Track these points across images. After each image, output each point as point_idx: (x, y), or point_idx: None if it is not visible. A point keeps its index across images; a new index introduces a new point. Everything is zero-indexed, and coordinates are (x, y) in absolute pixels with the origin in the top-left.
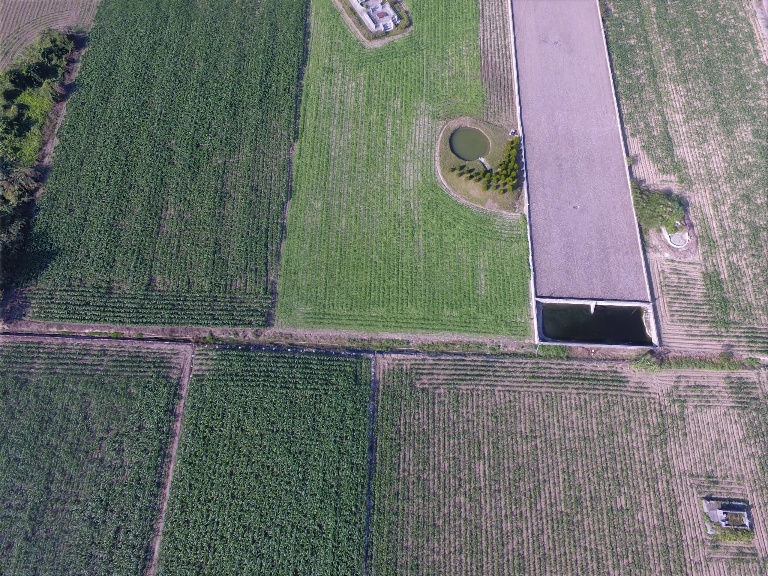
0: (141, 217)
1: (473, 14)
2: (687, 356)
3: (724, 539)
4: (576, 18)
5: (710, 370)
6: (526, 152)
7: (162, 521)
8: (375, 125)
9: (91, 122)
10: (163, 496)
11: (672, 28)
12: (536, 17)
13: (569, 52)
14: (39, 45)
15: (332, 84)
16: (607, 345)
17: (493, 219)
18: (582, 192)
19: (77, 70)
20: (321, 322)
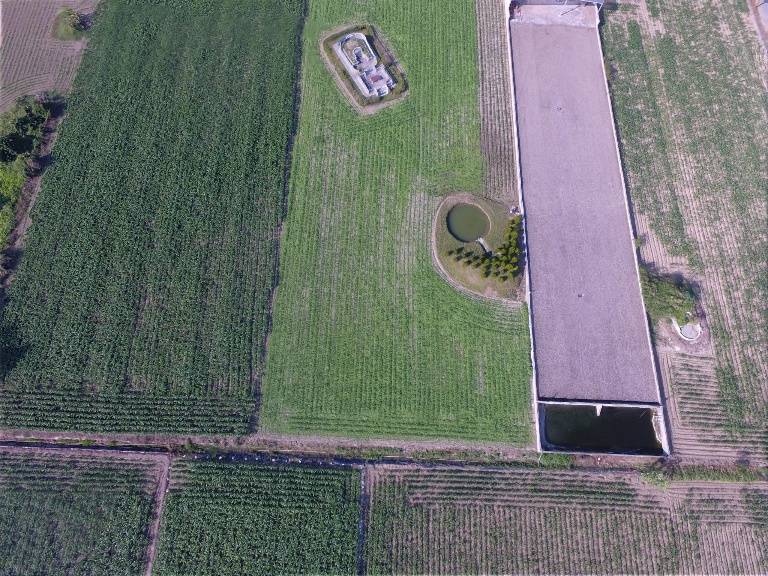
0: (117, 308)
1: (472, 77)
2: (700, 465)
3: None
4: (580, 81)
5: (725, 481)
6: (528, 232)
7: None
8: (368, 202)
9: (67, 200)
10: None
11: (681, 92)
12: (538, 80)
13: (573, 119)
14: (14, 114)
15: (323, 155)
16: (614, 454)
17: (492, 308)
18: (587, 278)
19: (54, 140)
20: (308, 428)
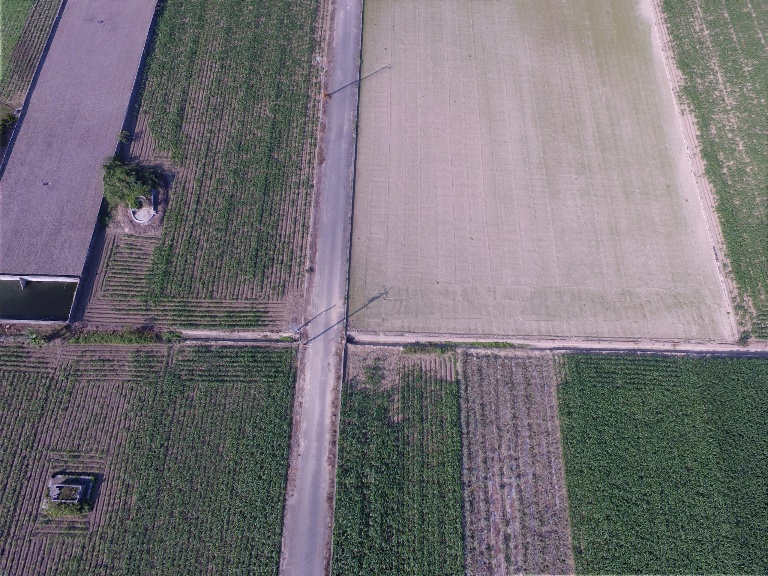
0: None
1: None
2: (103, 330)
3: None
4: None
5: (120, 344)
6: (20, 130)
7: None
8: None
9: None
10: None
11: (234, 6)
12: None
13: (111, 31)
14: None
15: None
16: (14, 320)
17: None
18: (61, 169)
19: None
20: None
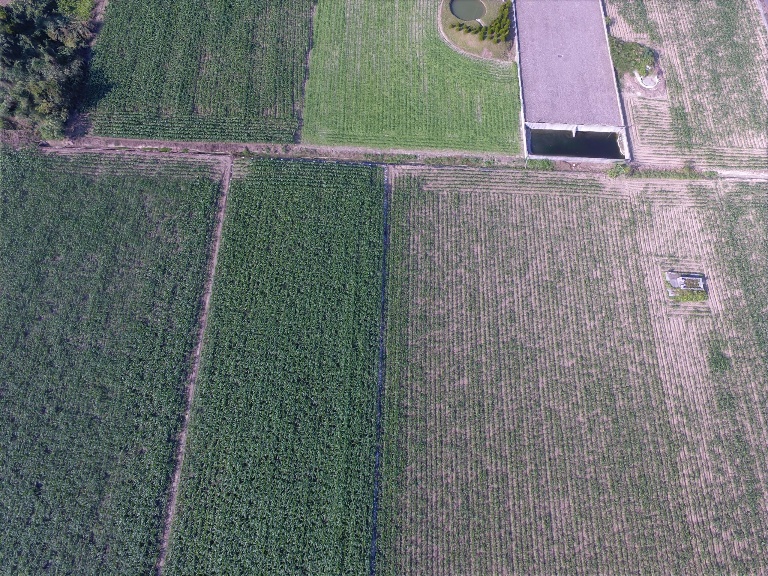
0: (183, 60)
1: None
2: (655, 169)
3: (682, 299)
4: None
5: (674, 179)
6: (517, 14)
7: (211, 283)
8: None
9: None
10: (211, 265)
11: None
12: None
13: None
14: None
15: None
16: (586, 158)
17: (488, 65)
18: (566, 44)
19: None
20: (341, 141)
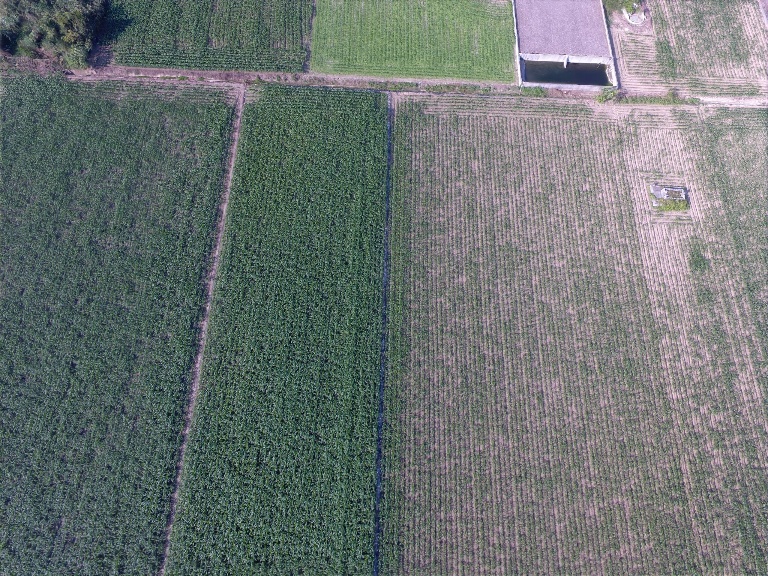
0: None
1: None
2: (641, 96)
3: (666, 208)
4: None
5: (659, 104)
6: None
7: (228, 193)
8: None
9: None
10: (227, 178)
11: None
12: None
13: None
14: None
15: None
16: (576, 85)
17: (485, 4)
18: None
19: None
20: (347, 70)
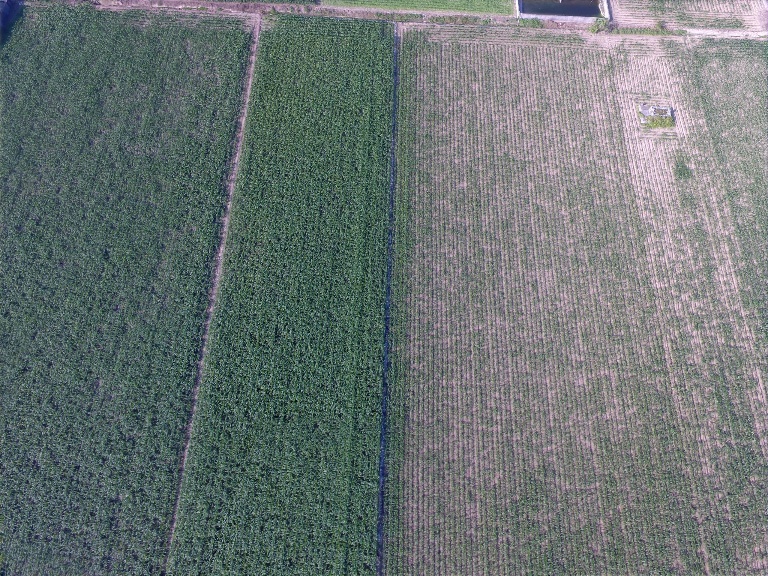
0: None
1: None
2: (631, 27)
3: (653, 124)
4: None
5: (648, 35)
6: None
7: (246, 108)
8: None
9: None
10: (245, 96)
11: None
12: None
13: None
14: None
15: None
16: (571, 17)
17: None
18: None
19: None
20: (356, 3)
